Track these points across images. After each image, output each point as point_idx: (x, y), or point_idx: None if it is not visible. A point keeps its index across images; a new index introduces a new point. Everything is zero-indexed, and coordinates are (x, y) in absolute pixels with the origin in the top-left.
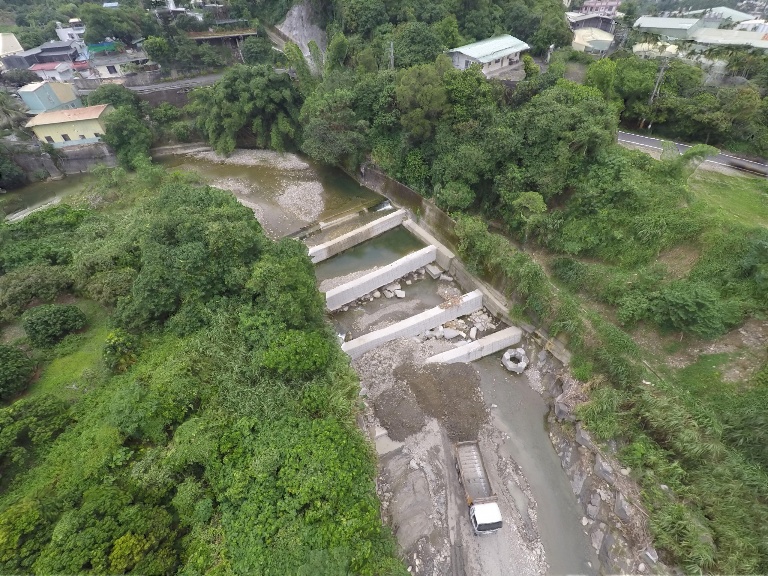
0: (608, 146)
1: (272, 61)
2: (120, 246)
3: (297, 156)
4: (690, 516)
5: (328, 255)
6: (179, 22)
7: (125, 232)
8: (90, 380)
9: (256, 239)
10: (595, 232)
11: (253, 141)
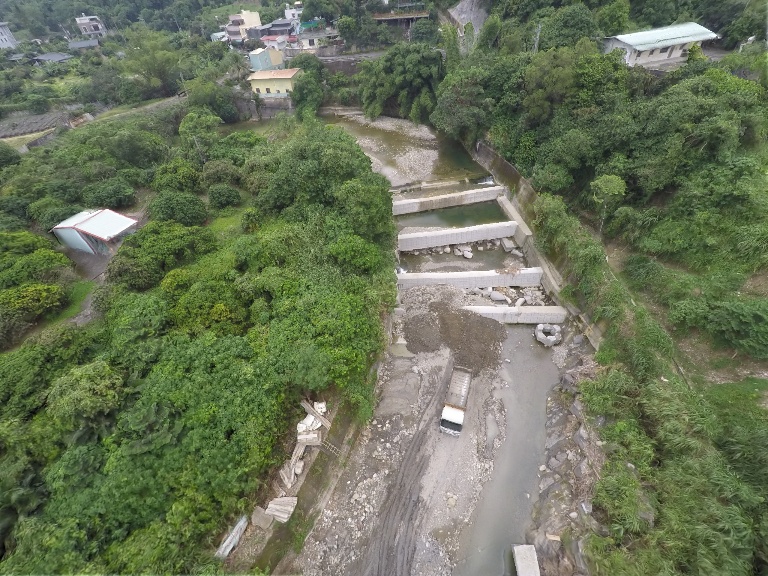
0: (757, 152)
1: (435, 42)
2: (272, 158)
3: (429, 129)
4: (642, 494)
5: (419, 209)
6: (369, 5)
7: (279, 153)
8: (231, 233)
9: (354, 167)
10: (689, 236)
11: (397, 111)
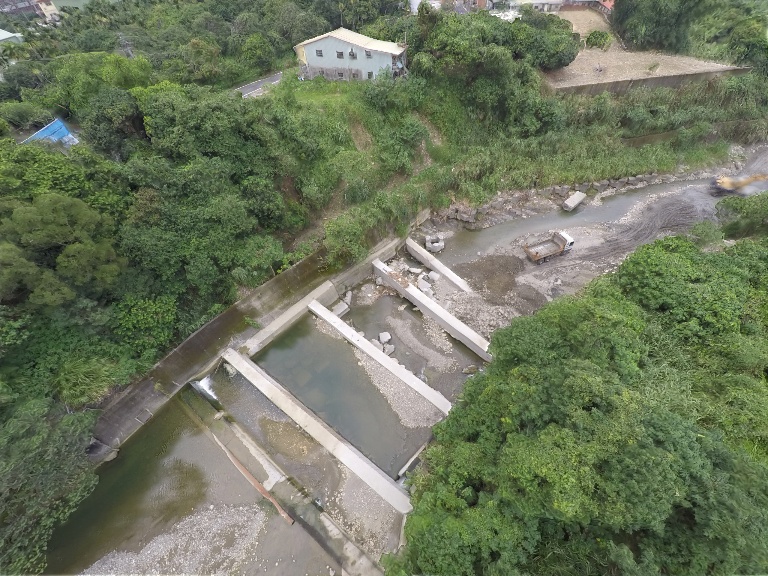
0: None
1: None
2: None
3: None
4: None
5: None
6: None
7: None
8: None
9: None
10: None
11: None
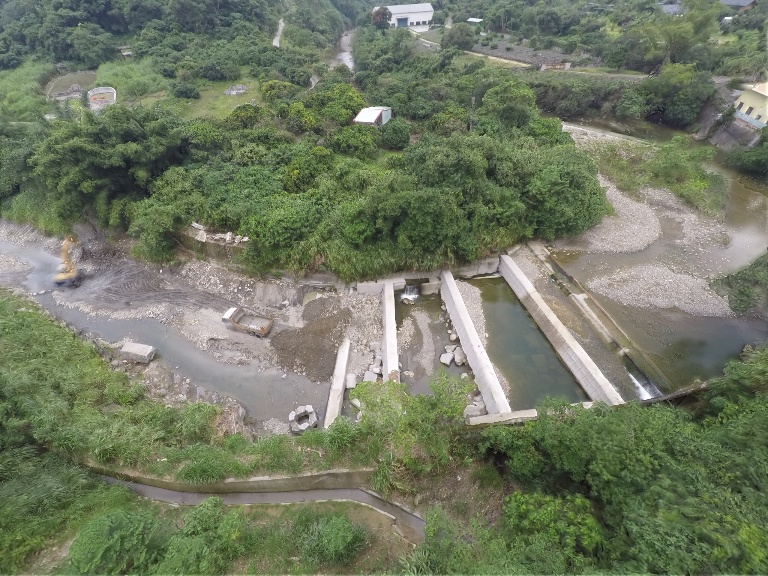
0: None
1: None
2: None
3: None
4: None
5: (523, 299)
6: None
7: None
8: None
9: (430, 173)
10: None
11: None
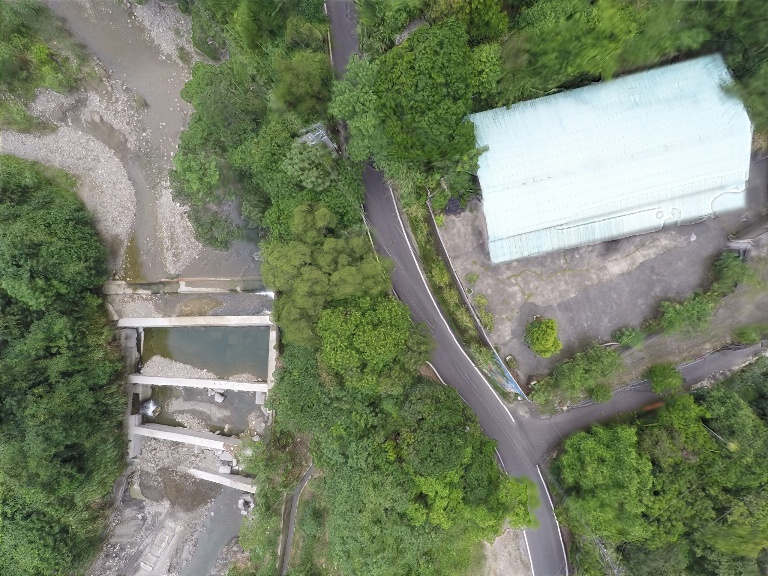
0: None
1: None
2: None
3: None
4: None
5: (175, 326)
6: None
7: None
8: None
9: None
10: None
11: None
